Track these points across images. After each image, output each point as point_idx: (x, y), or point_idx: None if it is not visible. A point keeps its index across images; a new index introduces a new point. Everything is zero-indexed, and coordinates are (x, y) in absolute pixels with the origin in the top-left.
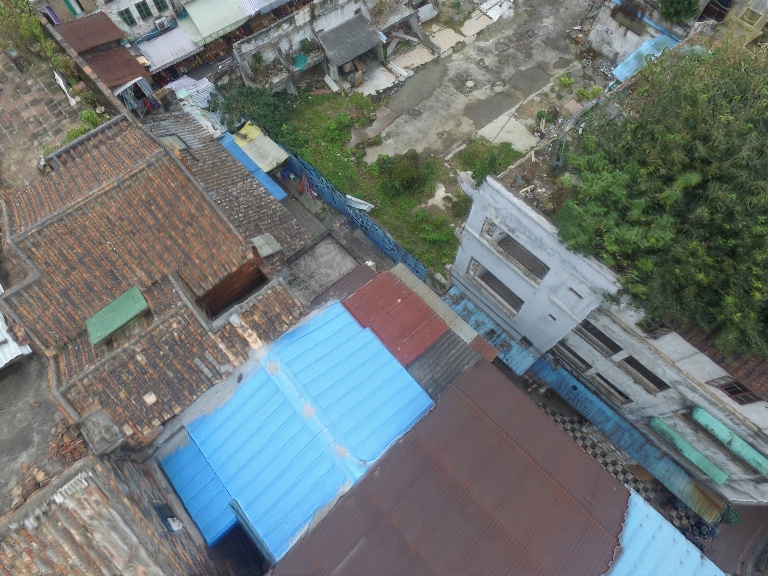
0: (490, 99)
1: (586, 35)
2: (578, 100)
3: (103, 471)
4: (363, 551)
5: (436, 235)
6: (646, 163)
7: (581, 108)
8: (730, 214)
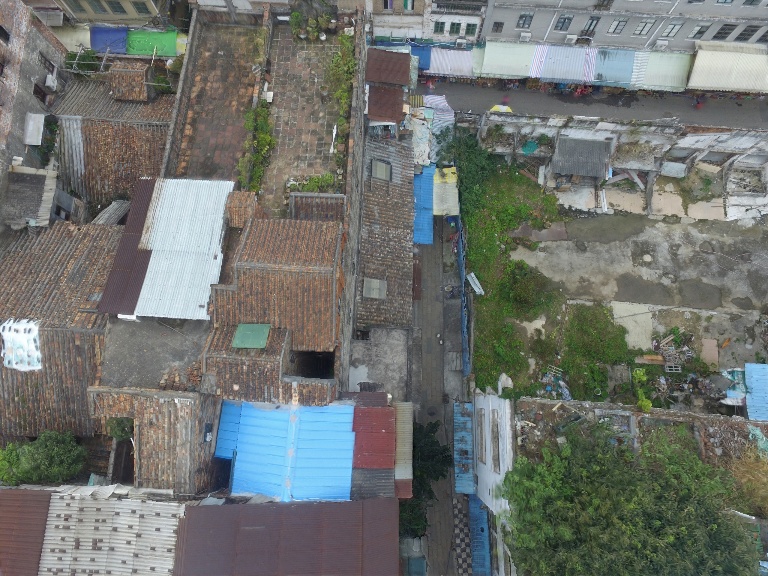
0: (650, 284)
1: None
2: (720, 345)
3: (198, 404)
4: (260, 531)
5: (504, 351)
6: (572, 498)
7: (715, 353)
8: (572, 572)
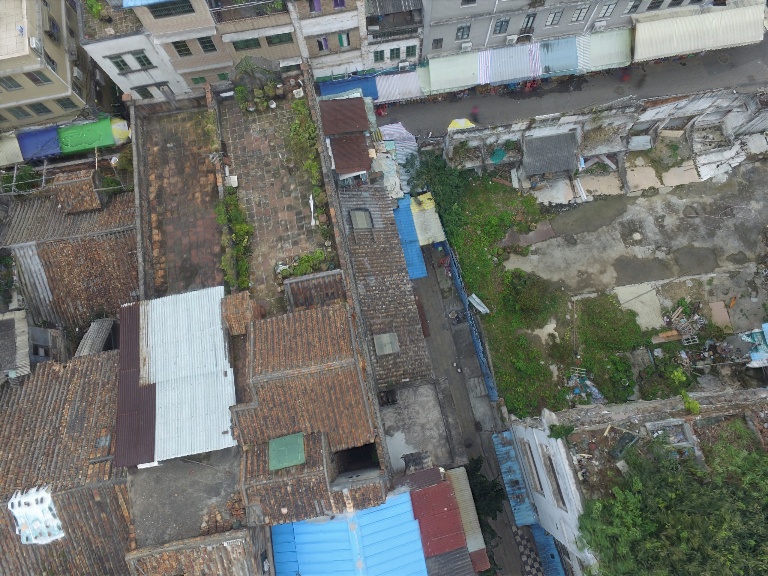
0: (646, 261)
1: None
2: (727, 305)
3: (249, 541)
4: None
5: (524, 365)
6: (658, 536)
7: (725, 314)
8: None
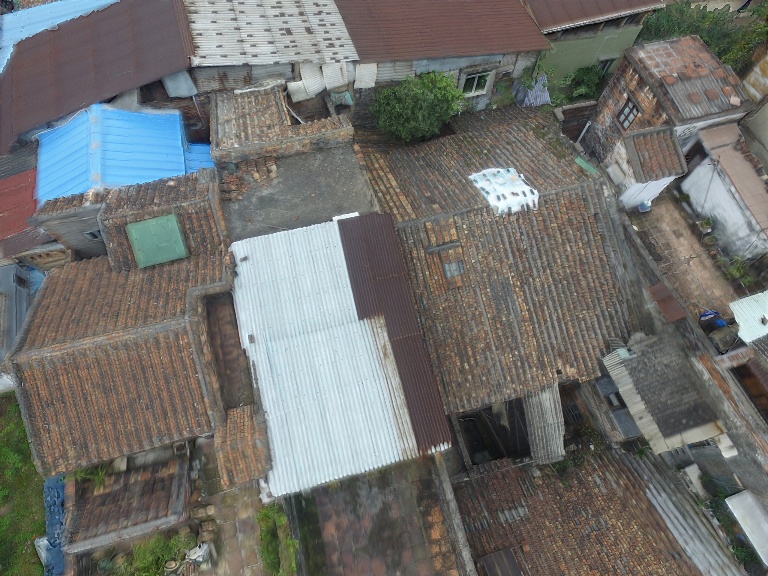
0: None
1: None
2: None
3: None
4: None
5: (7, 460)
6: None
7: None
8: None
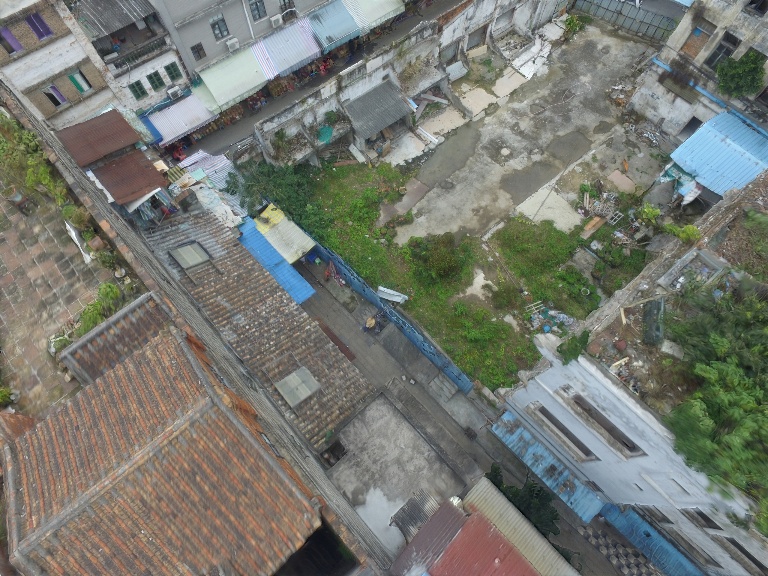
0: (528, 169)
1: (627, 96)
2: (623, 171)
3: None
4: None
5: (478, 332)
6: None
7: (626, 180)
8: None
